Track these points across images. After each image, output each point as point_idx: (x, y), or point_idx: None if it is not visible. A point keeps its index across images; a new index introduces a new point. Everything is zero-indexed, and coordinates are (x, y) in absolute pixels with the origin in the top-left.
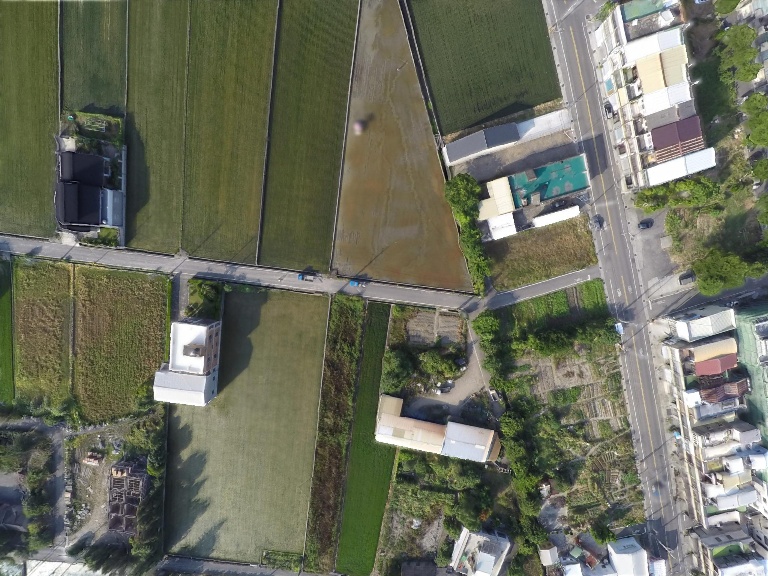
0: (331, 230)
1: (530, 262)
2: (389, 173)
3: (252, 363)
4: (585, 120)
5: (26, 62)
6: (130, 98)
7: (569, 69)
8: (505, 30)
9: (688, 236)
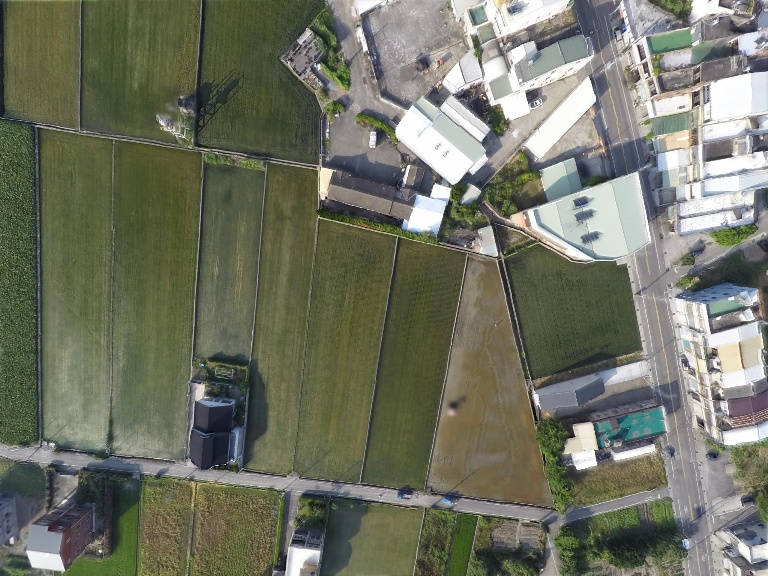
0: (428, 455)
1: (606, 483)
2: (483, 409)
3: (351, 563)
4: (662, 369)
5: (164, 319)
6: (255, 347)
7: (650, 327)
8: (594, 294)
9: (750, 463)
